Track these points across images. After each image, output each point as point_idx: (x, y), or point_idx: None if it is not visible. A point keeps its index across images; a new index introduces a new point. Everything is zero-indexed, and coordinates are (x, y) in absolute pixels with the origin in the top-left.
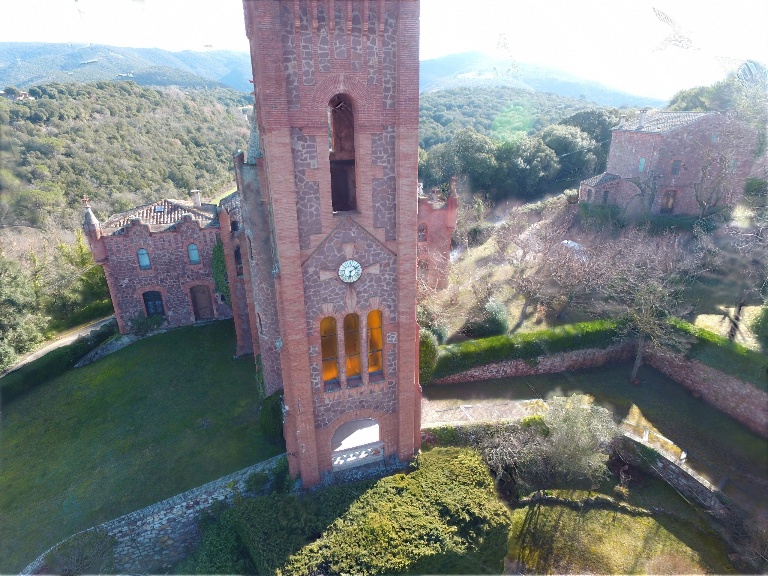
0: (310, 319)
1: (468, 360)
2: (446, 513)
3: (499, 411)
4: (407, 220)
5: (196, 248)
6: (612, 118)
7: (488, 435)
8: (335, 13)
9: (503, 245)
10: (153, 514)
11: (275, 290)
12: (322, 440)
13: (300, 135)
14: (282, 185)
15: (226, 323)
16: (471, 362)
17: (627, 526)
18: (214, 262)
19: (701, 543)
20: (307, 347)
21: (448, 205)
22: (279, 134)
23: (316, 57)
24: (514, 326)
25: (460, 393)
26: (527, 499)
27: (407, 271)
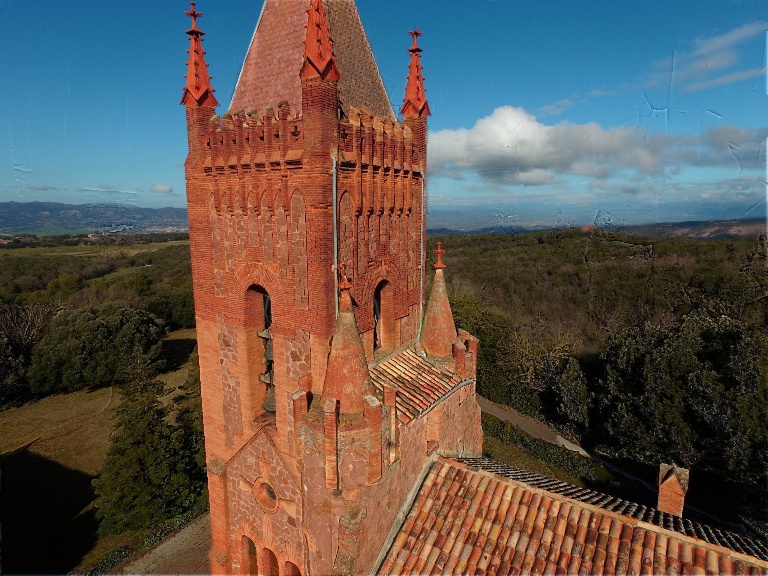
0: None
1: None
2: None
3: None
4: None
5: None
6: None
7: None
8: None
9: None
10: None
11: None
12: None
13: None
14: None
15: None
16: None
17: None
18: None
19: None
20: None
21: None
22: None
23: None
24: None
25: None
26: None
27: None
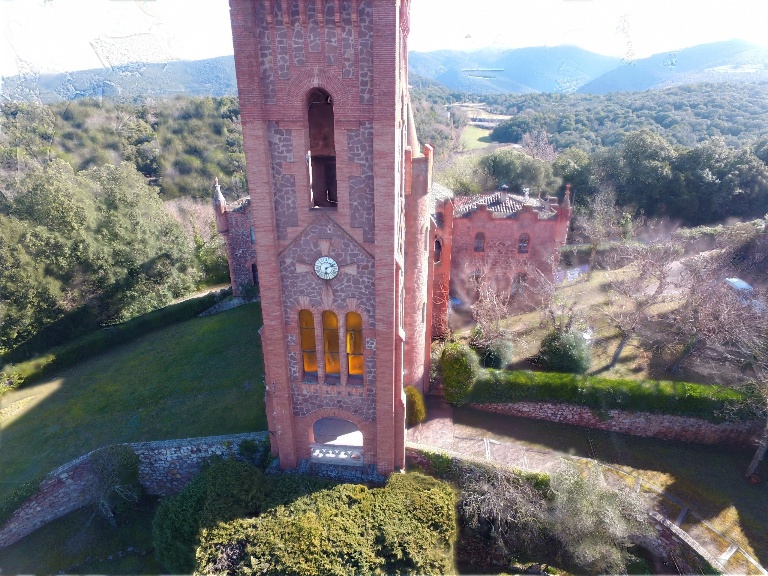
0: (288, 308)
1: (516, 392)
2: (381, 542)
3: (530, 458)
4: (383, 223)
5: None
6: None
7: (485, 478)
8: (309, 6)
9: (644, 271)
10: (166, 448)
11: None
12: (300, 428)
13: (277, 128)
14: (256, 176)
15: None
16: (520, 395)
17: None
18: None
19: None
20: (282, 334)
21: (558, 216)
22: (252, 127)
23: (291, 51)
24: (601, 367)
25: (496, 425)
26: (521, 567)
27: (384, 277)
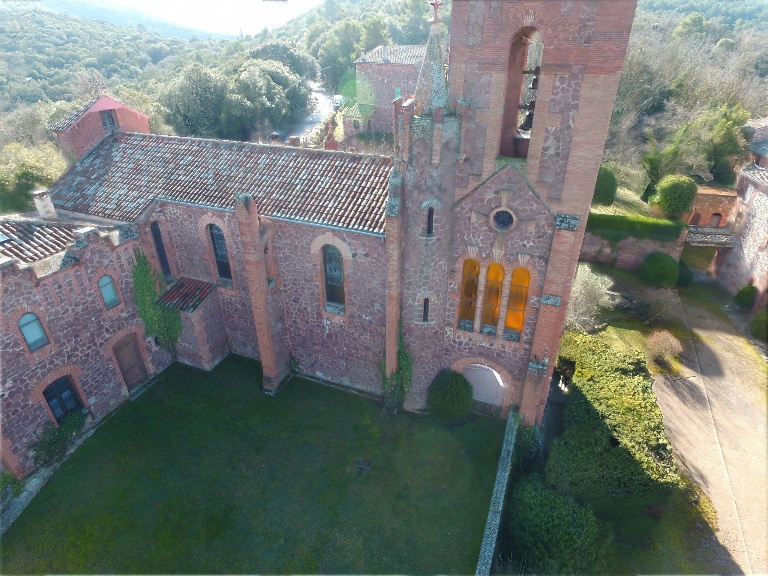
0: None
1: None
2: (625, 372)
3: None
4: None
5: (109, 281)
6: (297, 51)
7: None
8: None
9: None
10: None
11: (455, 262)
12: None
13: None
14: None
15: (176, 372)
16: None
17: (608, 337)
18: (138, 293)
19: (632, 325)
20: None
21: None
22: None
23: None
24: None
25: None
26: None
27: None
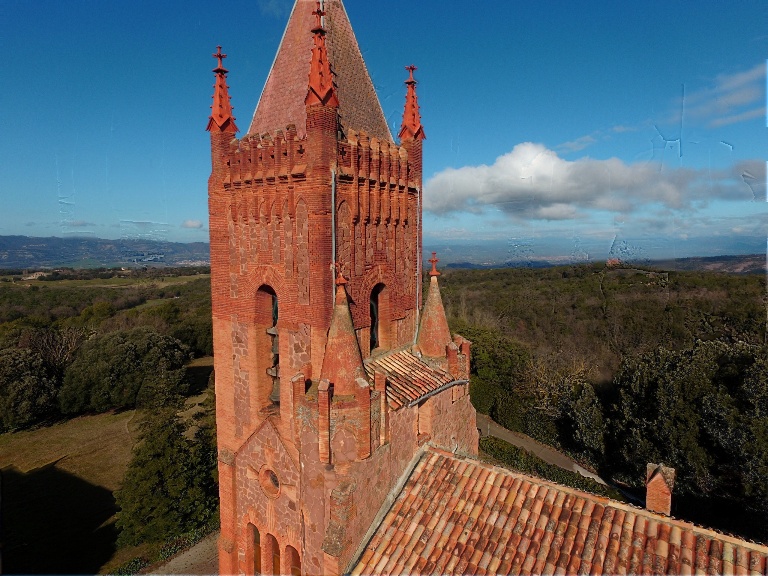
0: None
1: None
2: None
3: None
4: None
5: None
6: None
7: None
8: None
9: None
10: None
11: None
12: None
13: None
14: None
15: None
16: None
17: None
18: None
19: None
20: None
21: None
22: None
23: None
24: None
25: None
26: None
27: None
